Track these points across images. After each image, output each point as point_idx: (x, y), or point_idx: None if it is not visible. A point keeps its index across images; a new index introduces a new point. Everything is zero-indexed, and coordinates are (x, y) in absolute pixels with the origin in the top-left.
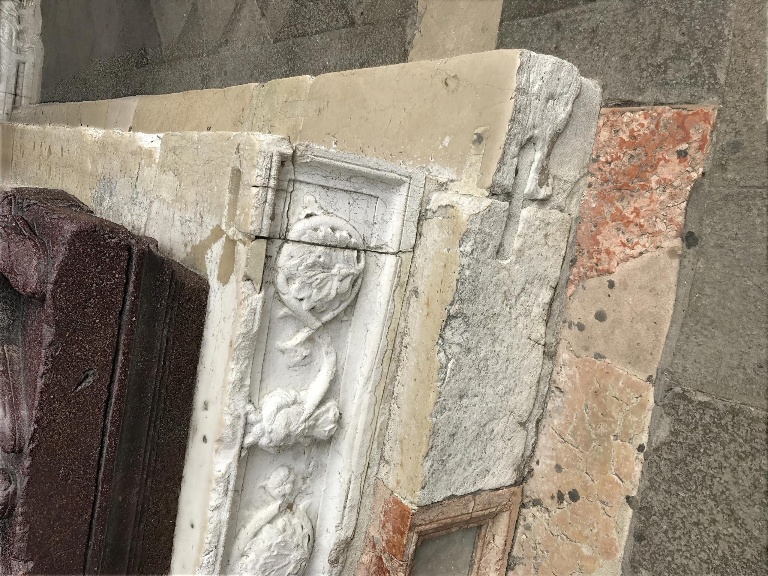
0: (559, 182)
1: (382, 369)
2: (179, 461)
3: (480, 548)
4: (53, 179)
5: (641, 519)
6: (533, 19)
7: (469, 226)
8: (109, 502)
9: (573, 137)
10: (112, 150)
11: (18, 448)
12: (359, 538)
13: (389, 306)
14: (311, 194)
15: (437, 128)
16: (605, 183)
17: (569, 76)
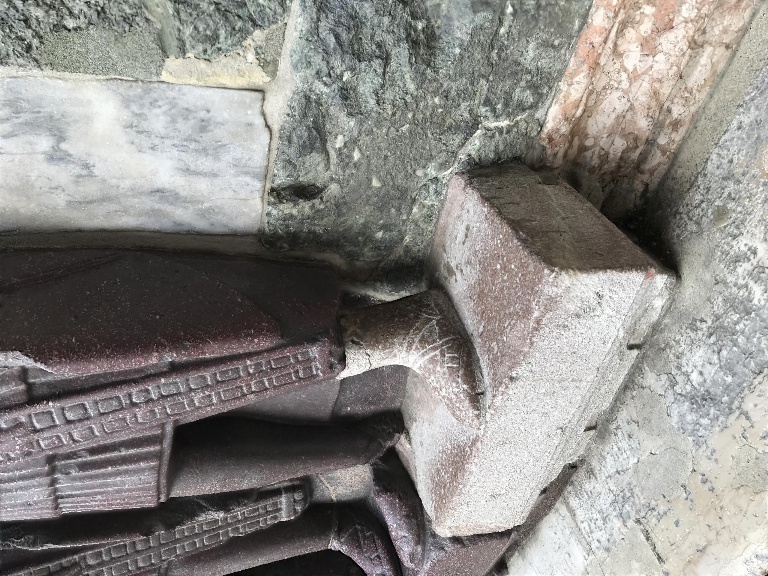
0: None
1: None
2: None
3: None
4: None
5: None
6: None
7: None
8: None
9: None
10: None
11: None
12: None
13: None
14: None
15: None
16: None
17: None
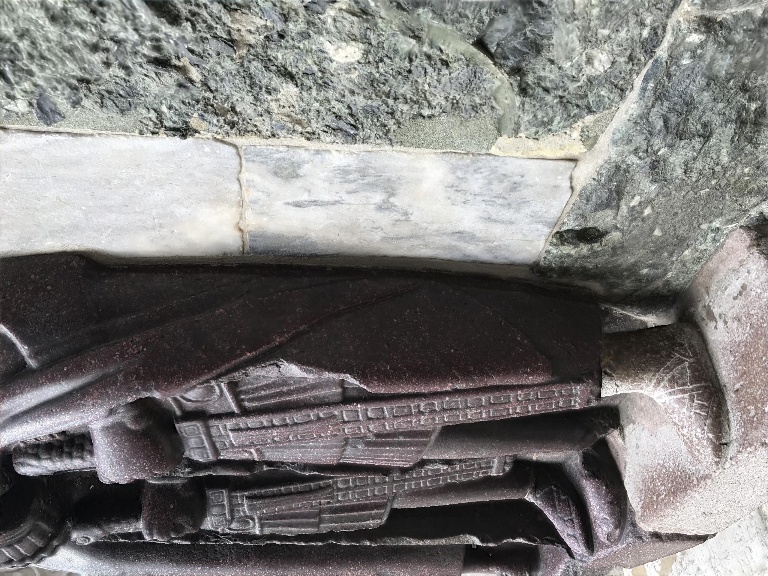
0: None
1: None
2: None
3: None
4: None
5: None
6: None
7: None
8: None
9: None
10: None
11: None
12: None
13: None
14: None
15: None
16: None
17: None
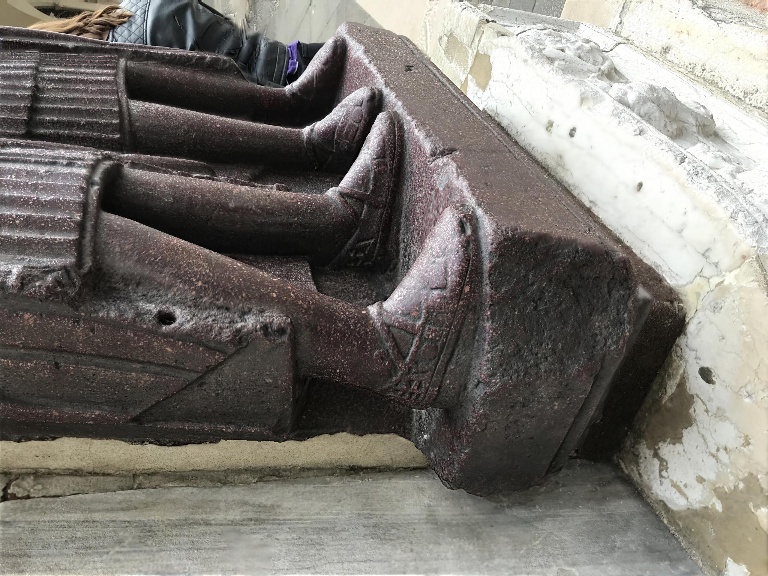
0: None
1: None
2: None
3: None
4: None
5: None
6: None
7: None
8: None
9: None
10: None
11: (377, 91)
12: None
13: None
14: None
15: None
16: None
17: None
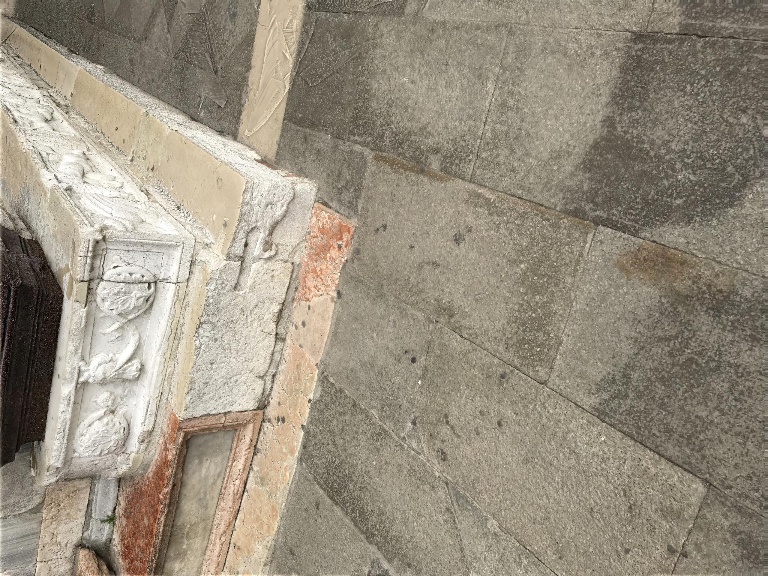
0: (283, 246)
1: (168, 344)
2: (48, 384)
3: (236, 442)
4: (1, 155)
5: (306, 437)
6: (296, 127)
7: (212, 276)
8: (3, 406)
9: (291, 221)
10: (30, 170)
11: None
12: (157, 431)
13: (171, 311)
14: (118, 255)
15: (212, 207)
16: (311, 249)
17: (283, 191)
